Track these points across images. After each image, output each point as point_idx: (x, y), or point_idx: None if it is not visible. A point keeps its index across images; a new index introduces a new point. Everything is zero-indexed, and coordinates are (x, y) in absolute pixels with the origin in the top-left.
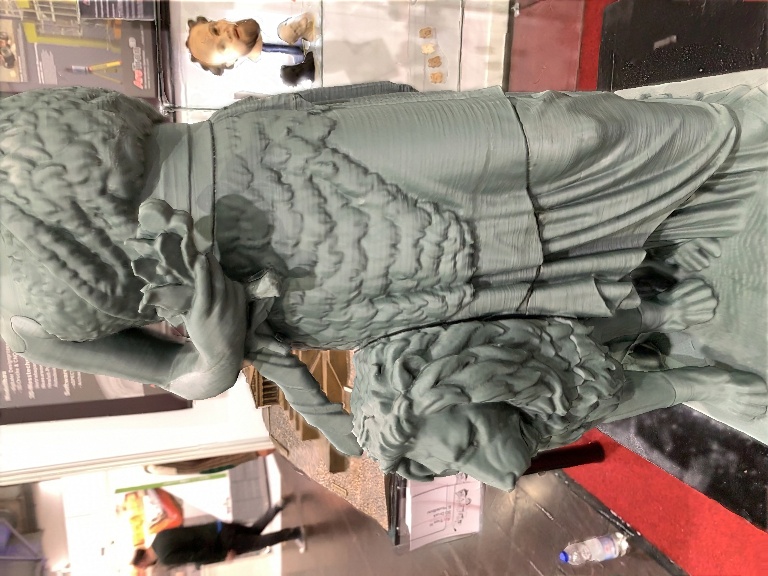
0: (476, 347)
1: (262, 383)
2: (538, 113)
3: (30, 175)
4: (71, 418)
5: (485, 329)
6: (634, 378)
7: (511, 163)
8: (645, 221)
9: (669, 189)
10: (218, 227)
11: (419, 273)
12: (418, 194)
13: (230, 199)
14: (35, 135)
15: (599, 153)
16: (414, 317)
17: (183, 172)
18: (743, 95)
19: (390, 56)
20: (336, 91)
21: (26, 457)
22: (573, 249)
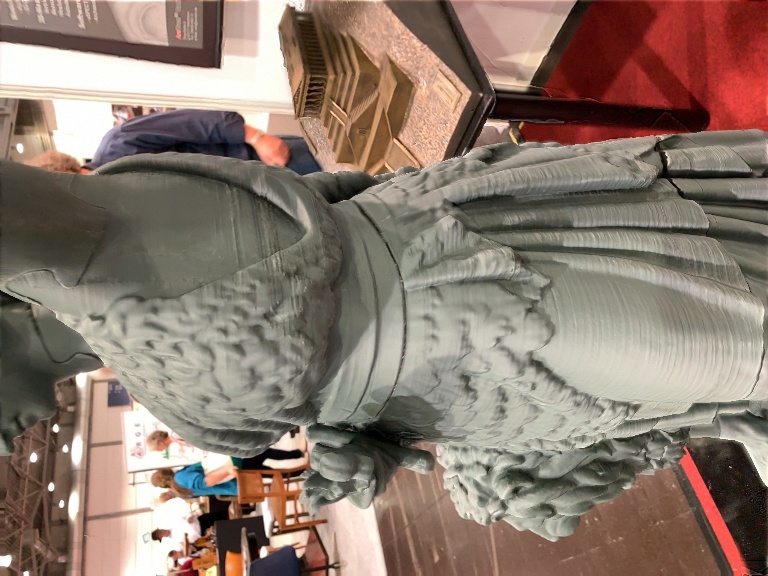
0: (580, 472)
1: (306, 96)
2: None
3: (203, 409)
4: (87, 51)
5: (595, 455)
6: None
7: None
8: None
9: None
10: (386, 411)
11: None
12: None
13: (408, 400)
14: (211, 377)
15: None
16: None
17: (364, 372)
18: None
19: None
20: (559, 185)
21: (40, 76)
22: None
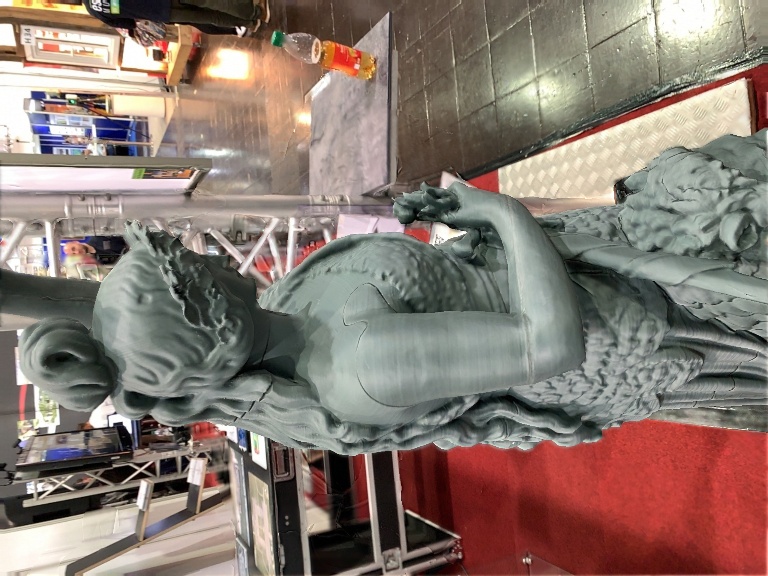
0: None
1: None
2: None
3: None
4: None
5: None
6: None
7: None
8: None
9: None
10: None
11: None
12: None
13: None
14: None
15: None
16: None
17: None
18: None
19: None
20: None
21: None
22: None
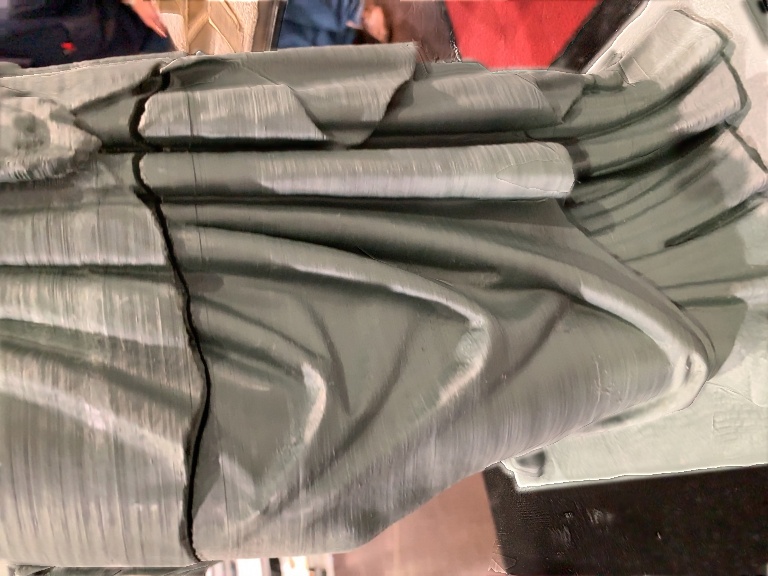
0: None
1: None
2: (237, 538)
3: None
4: None
5: None
6: None
7: None
8: None
9: None
10: None
11: None
12: None
13: None
14: None
15: None
16: None
17: None
18: None
19: None
20: None
21: None
22: None
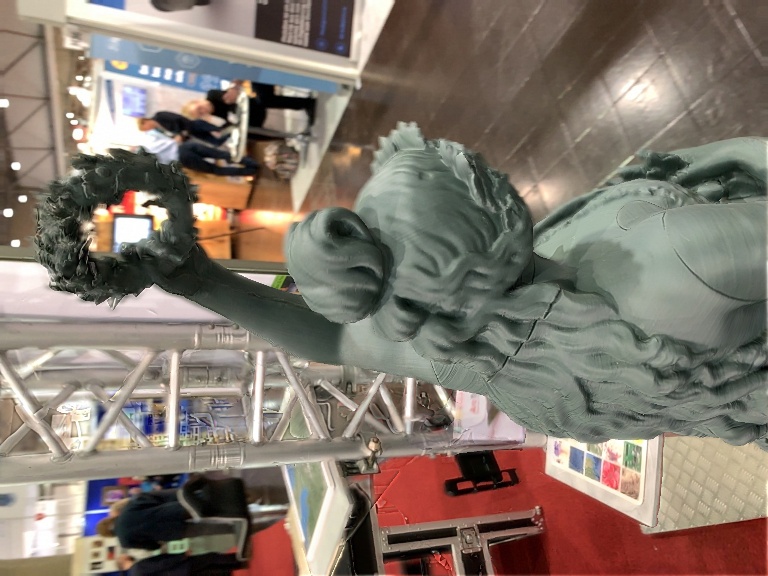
0: None
1: None
2: None
3: None
4: None
5: None
6: None
7: None
8: None
9: None
10: None
11: None
12: None
13: None
14: None
15: None
16: None
17: None
18: None
19: None
20: None
21: None
22: None
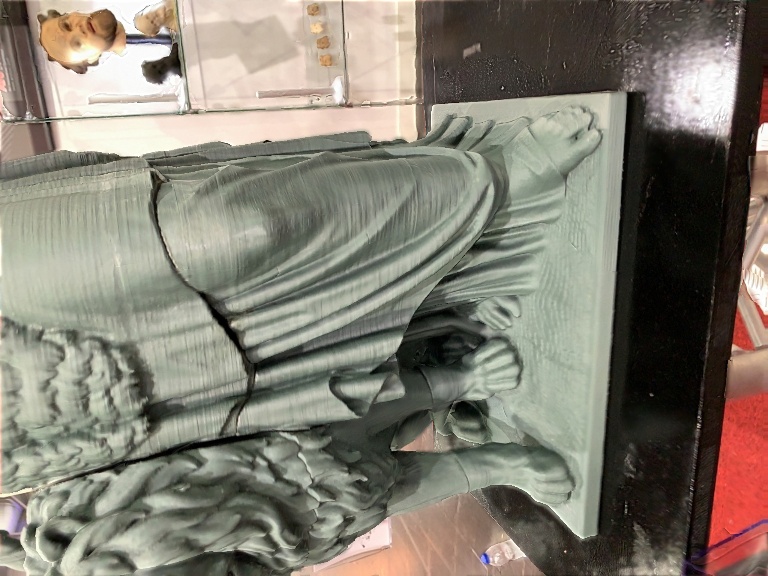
0: (153, 495)
1: None
2: (184, 212)
3: None
4: None
5: (171, 467)
6: (423, 465)
7: (153, 279)
8: (404, 296)
9: (410, 268)
10: None
11: (59, 419)
12: (41, 324)
13: None
14: None
15: (290, 246)
16: (69, 467)
17: None
18: (516, 135)
19: (287, 34)
20: None
21: None
22: (308, 342)
